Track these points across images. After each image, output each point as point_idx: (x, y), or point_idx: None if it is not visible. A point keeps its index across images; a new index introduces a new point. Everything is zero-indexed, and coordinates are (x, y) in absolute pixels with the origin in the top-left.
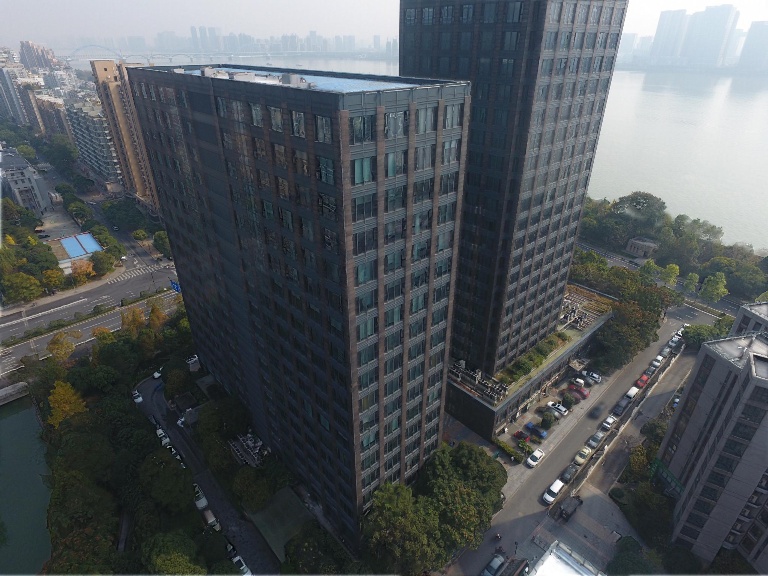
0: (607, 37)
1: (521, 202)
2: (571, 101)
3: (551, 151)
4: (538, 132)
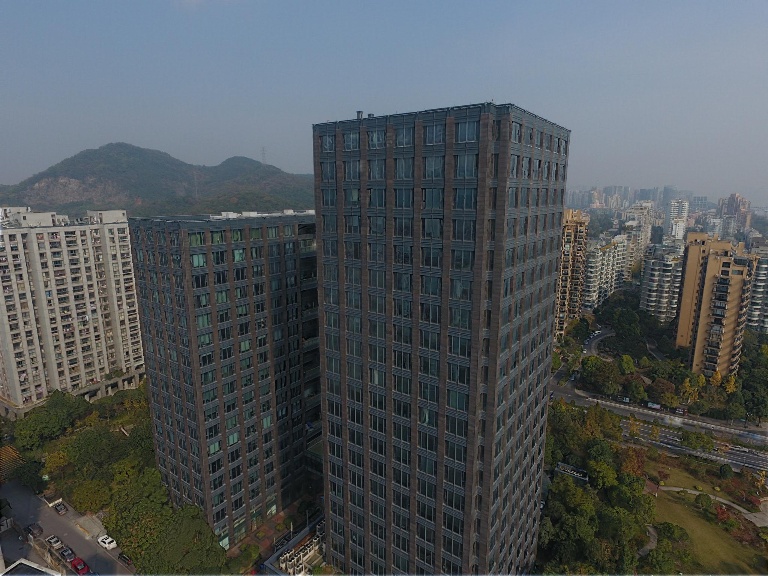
0: (444, 193)
1: (327, 358)
2: (385, 266)
3: (362, 318)
4: (335, 288)
